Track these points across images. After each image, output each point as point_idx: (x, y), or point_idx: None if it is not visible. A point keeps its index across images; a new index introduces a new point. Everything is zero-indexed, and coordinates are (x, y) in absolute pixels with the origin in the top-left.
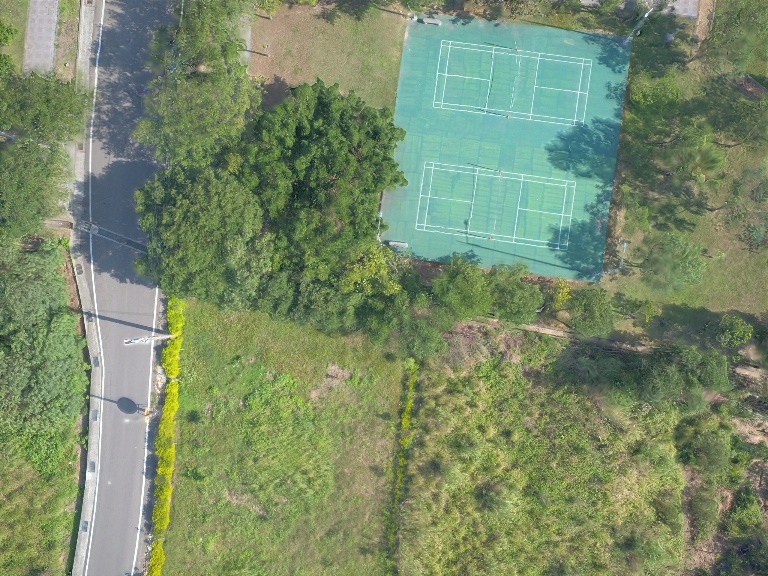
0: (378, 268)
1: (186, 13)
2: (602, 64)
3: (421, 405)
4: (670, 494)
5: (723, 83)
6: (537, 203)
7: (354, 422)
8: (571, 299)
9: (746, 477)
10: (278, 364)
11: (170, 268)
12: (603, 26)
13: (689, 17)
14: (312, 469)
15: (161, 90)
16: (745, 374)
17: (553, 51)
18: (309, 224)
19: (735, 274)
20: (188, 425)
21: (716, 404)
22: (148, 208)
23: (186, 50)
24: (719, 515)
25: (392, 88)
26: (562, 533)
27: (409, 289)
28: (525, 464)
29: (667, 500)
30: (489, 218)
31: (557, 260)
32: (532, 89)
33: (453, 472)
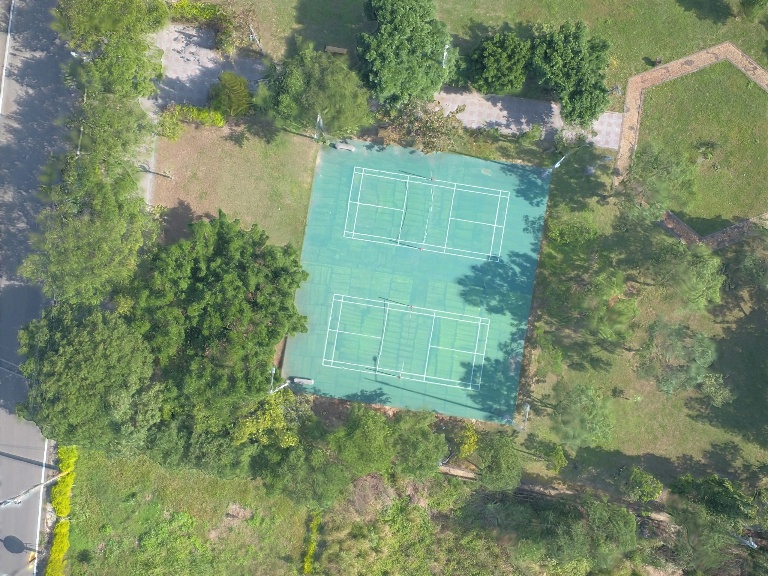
0: (273, 421)
1: (86, 129)
2: (520, 197)
3: (324, 549)
4: None
5: (643, 219)
6: (449, 341)
7: (255, 564)
8: (478, 449)
9: None
10: (176, 502)
11: (50, 420)
12: (522, 156)
13: (610, 150)
14: None
15: (46, 227)
16: (660, 520)
17: (470, 182)
18: (198, 379)
19: (652, 417)
20: (79, 565)
21: None
22: (32, 349)
23: (72, 188)
24: None
25: (301, 215)
26: None
27: (308, 438)
28: None
29: None
30: (399, 355)
31: (468, 401)
32: (447, 221)
33: None
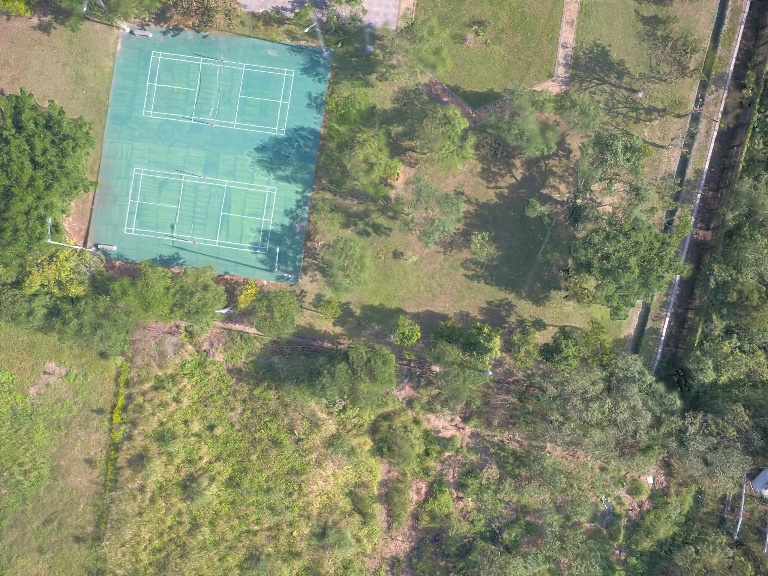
0: (58, 271)
1: None
2: (303, 75)
3: (130, 401)
4: (366, 486)
5: (420, 93)
6: (239, 208)
7: (70, 417)
8: (255, 300)
9: (439, 469)
10: None
11: None
12: (306, 38)
13: (388, 29)
14: (29, 462)
15: None
16: None
17: (257, 62)
18: None
19: (430, 276)
20: None
21: (410, 400)
22: None
23: None
24: (414, 506)
25: (105, 97)
26: (260, 523)
27: (98, 291)
28: (228, 457)
29: (363, 491)
30: (194, 222)
31: (257, 263)
32: (237, 99)
33: (150, 465)
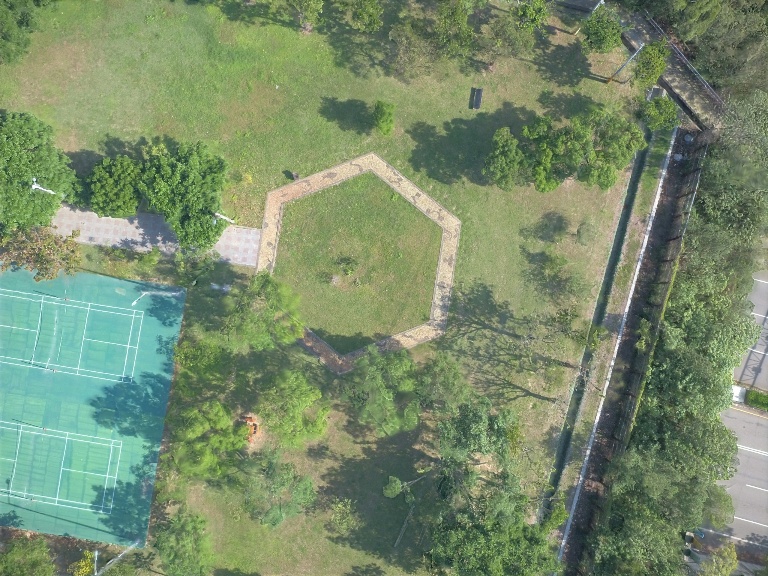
0: None
1: None
2: (153, 317)
3: None
4: None
5: (282, 337)
6: (81, 463)
7: None
8: None
9: None
10: None
11: None
12: (158, 274)
13: (247, 267)
14: None
15: None
16: None
17: (103, 301)
18: None
19: (290, 539)
20: None
21: None
22: None
23: None
24: None
25: None
26: None
27: None
28: None
29: None
30: (32, 478)
31: (100, 524)
32: (80, 342)
33: None
